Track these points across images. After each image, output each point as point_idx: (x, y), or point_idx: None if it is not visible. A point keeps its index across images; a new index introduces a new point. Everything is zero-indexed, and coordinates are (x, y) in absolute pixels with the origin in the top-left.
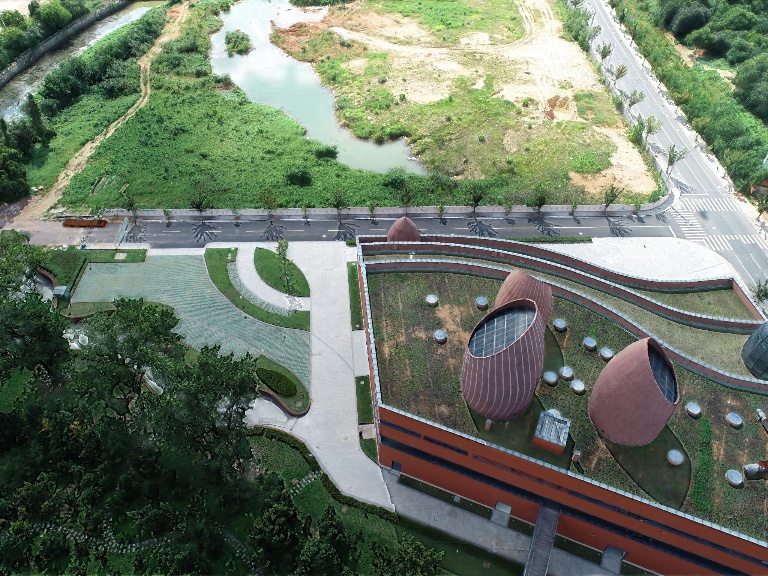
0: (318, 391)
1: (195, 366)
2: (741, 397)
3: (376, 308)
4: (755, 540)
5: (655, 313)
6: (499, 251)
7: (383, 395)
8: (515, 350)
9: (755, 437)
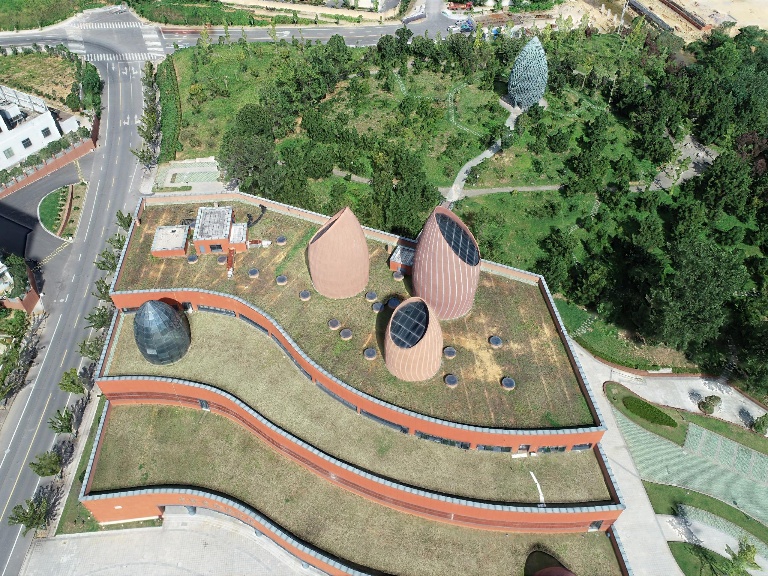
0: (601, 405)
1: (710, 269)
2: (233, 291)
3: (570, 377)
4: (295, 208)
5: (244, 403)
6: (417, 491)
7: (540, 294)
8: (449, 215)
9: (245, 264)
